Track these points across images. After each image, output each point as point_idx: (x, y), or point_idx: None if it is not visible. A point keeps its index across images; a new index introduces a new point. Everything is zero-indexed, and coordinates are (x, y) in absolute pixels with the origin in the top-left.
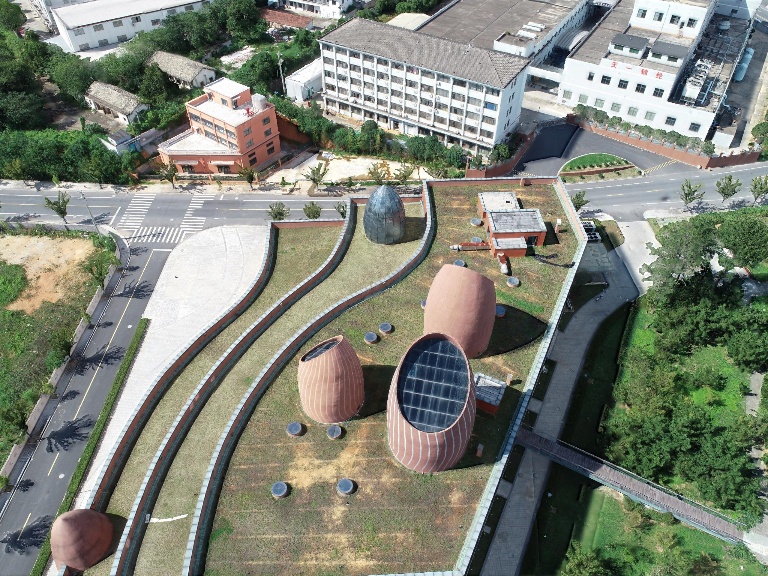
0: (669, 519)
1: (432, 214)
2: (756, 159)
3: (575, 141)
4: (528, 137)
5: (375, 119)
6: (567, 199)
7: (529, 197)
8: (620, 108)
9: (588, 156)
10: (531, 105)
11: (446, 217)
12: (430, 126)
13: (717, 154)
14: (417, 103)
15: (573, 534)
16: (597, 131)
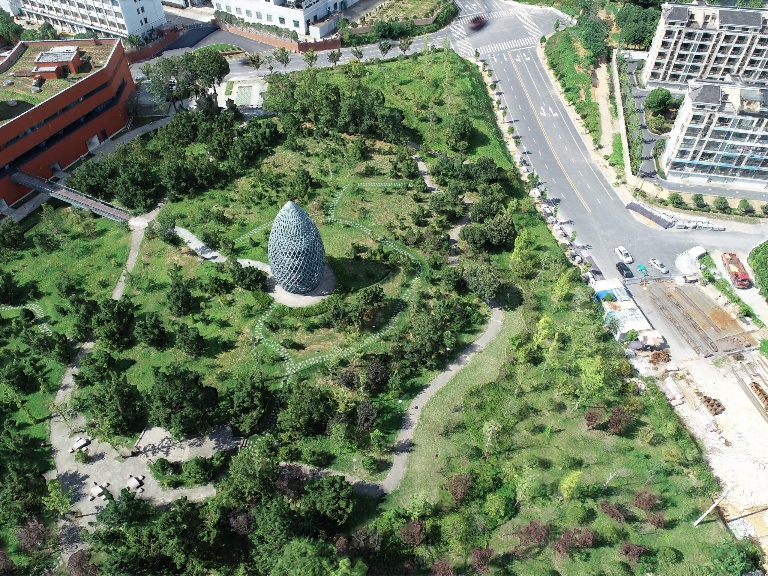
0: (89, 212)
1: (15, 60)
2: (340, 46)
3: (209, 37)
4: (165, 32)
5: (59, 25)
6: (113, 49)
7: (93, 51)
8: (251, 14)
9: (212, 46)
10: (194, 16)
11: (23, 62)
12: (89, 25)
13: (308, 42)
14: (77, 7)
15: (34, 227)
16: (231, 31)
